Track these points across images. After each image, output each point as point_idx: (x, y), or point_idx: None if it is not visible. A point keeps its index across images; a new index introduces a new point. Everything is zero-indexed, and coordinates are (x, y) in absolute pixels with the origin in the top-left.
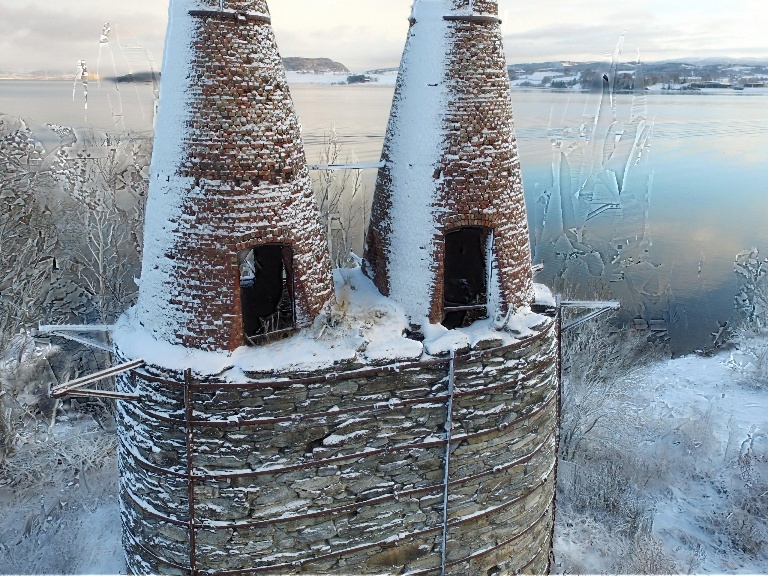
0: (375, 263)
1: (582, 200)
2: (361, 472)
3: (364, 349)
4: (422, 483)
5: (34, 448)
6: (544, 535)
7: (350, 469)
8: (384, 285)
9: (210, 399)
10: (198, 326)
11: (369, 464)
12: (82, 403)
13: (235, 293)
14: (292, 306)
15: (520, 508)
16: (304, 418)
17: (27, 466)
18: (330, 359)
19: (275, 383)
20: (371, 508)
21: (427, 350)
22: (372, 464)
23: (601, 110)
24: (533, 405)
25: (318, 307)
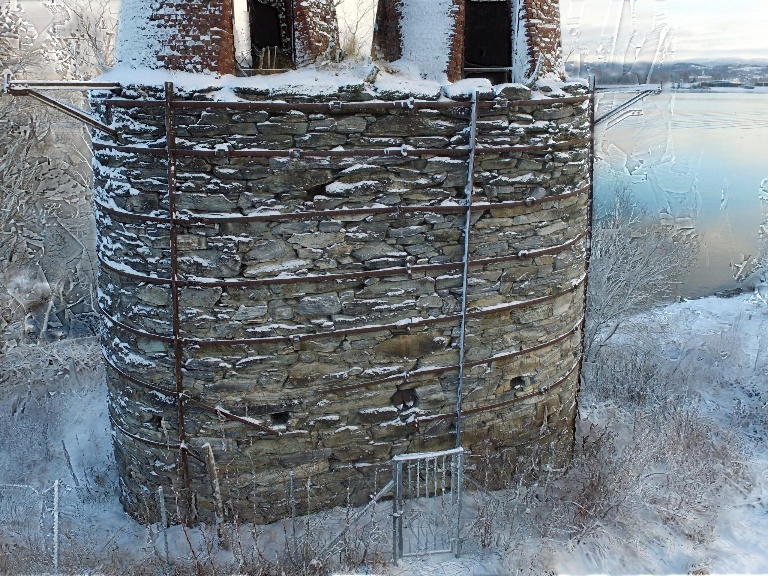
0: (385, 46)
1: (601, 110)
2: (369, 233)
3: (373, 81)
4: (438, 259)
5: (24, 350)
6: (572, 360)
7: (356, 228)
8: (396, 48)
9: (195, 122)
10: (182, 42)
11: (378, 225)
12: (77, 314)
13: (225, 2)
14: (291, 41)
15: (548, 310)
16: (304, 155)
17: (16, 364)
18: (334, 84)
19: (270, 104)
20: (380, 283)
21: (445, 92)
22: (382, 226)
23: (621, 24)
24: (564, 186)
25: (321, 47)
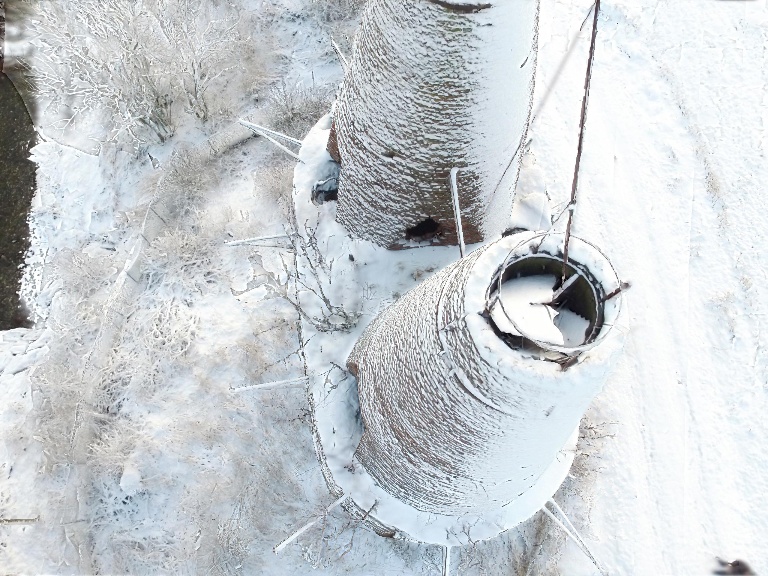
0: None
1: None
2: None
3: None
4: None
5: None
6: None
7: None
8: None
9: None
10: None
11: None
12: None
13: None
14: None
15: None
16: None
17: None
18: None
19: None
20: None
21: None
22: None
23: None
24: None
25: None
